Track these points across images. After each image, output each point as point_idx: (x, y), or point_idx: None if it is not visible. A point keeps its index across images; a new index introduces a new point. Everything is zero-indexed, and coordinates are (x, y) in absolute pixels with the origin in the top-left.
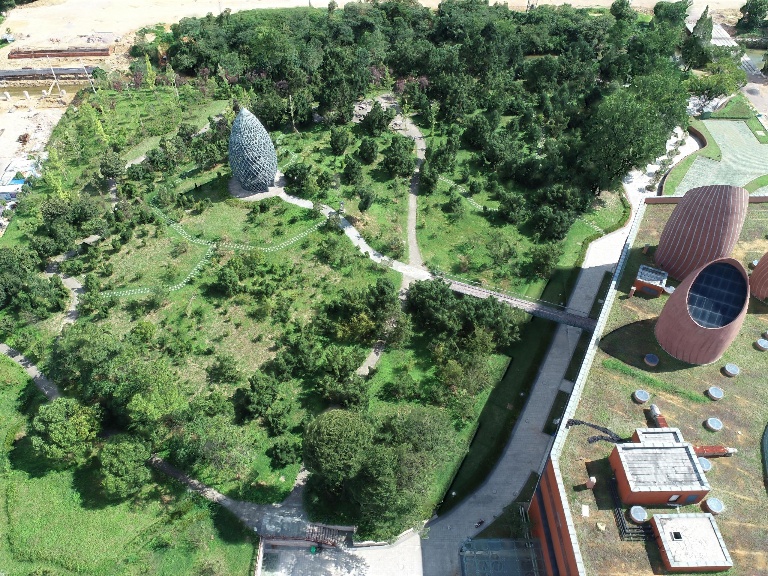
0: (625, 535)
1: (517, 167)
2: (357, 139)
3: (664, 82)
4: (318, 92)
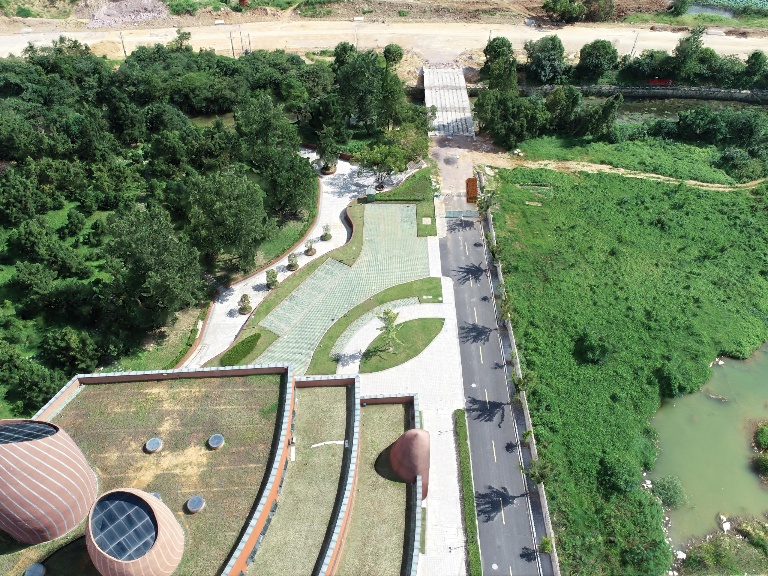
0: None
1: (45, 297)
2: None
3: (220, 185)
4: None
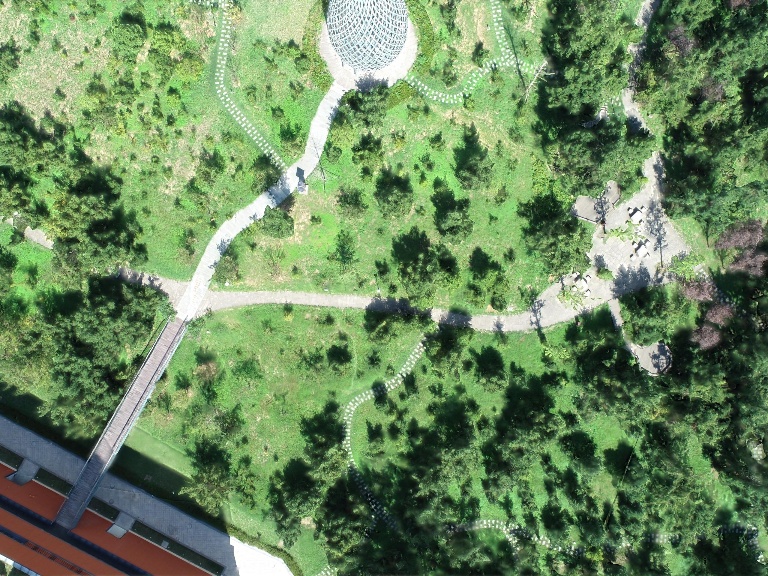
0: None
1: None
2: (517, 207)
3: None
4: (671, 121)
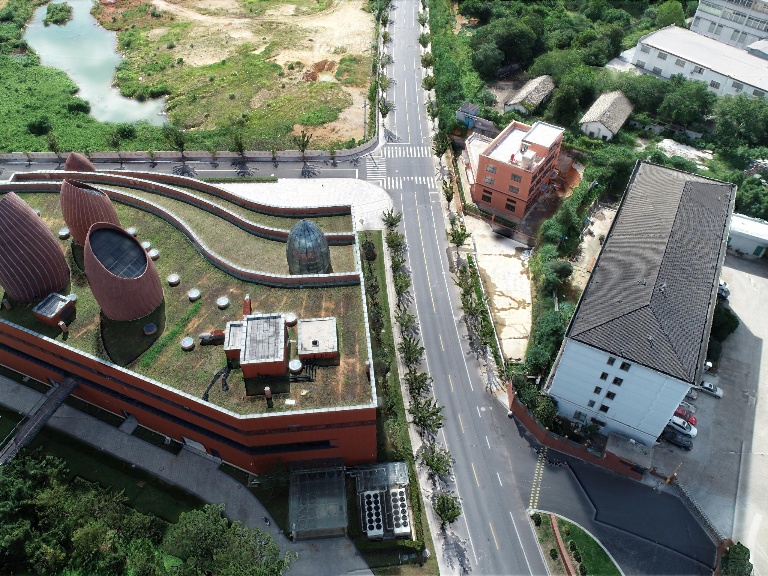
0: (311, 378)
1: None
2: None
3: None
4: None
